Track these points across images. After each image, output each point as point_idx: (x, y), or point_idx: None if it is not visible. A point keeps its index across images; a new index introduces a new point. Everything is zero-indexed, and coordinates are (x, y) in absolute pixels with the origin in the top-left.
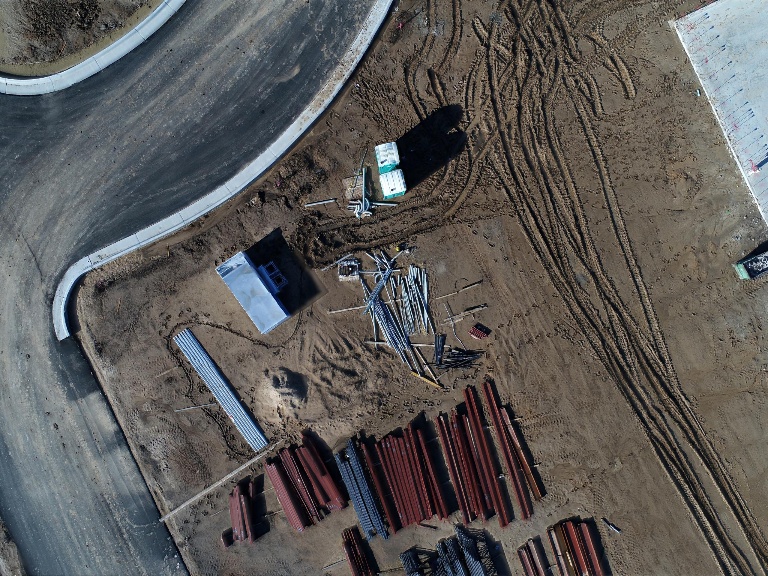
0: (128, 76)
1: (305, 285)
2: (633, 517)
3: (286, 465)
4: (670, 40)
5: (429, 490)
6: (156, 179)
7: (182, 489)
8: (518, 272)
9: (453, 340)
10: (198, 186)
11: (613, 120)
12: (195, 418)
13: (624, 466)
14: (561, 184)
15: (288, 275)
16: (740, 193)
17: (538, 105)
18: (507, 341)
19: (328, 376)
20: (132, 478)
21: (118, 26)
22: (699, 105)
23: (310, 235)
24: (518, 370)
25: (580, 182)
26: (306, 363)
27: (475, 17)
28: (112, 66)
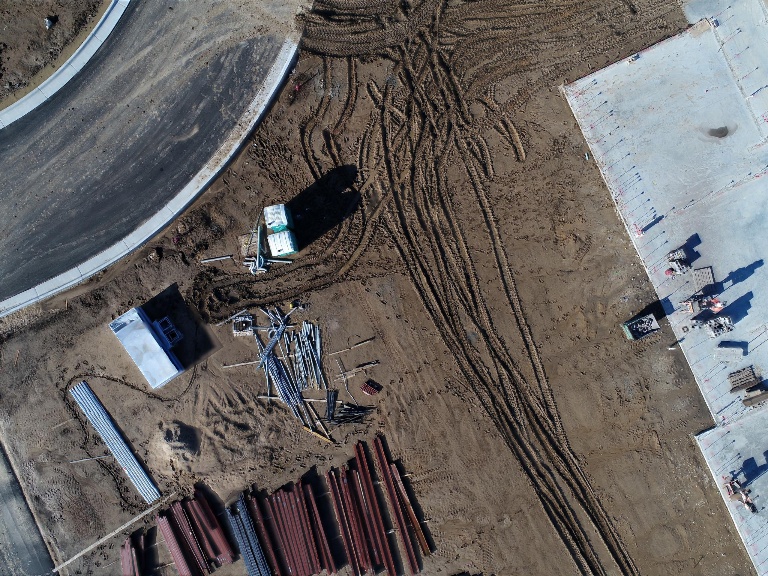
0: (31, 133)
1: (200, 340)
2: (522, 574)
3: (178, 518)
4: (559, 105)
5: (319, 545)
6: (56, 234)
7: (76, 540)
8: (410, 329)
9: (345, 396)
10: (97, 241)
11: (504, 182)
12: (90, 470)
13: (513, 523)
14: (453, 244)
15: (183, 330)
16: (628, 255)
17: (431, 166)
18: (398, 397)
19: (221, 430)
20: (27, 528)
21: (22, 84)
22: (588, 168)
23: (206, 290)
24: (409, 426)
25: (471, 242)
26: (200, 417)
27: (370, 80)
28: (15, 123)
